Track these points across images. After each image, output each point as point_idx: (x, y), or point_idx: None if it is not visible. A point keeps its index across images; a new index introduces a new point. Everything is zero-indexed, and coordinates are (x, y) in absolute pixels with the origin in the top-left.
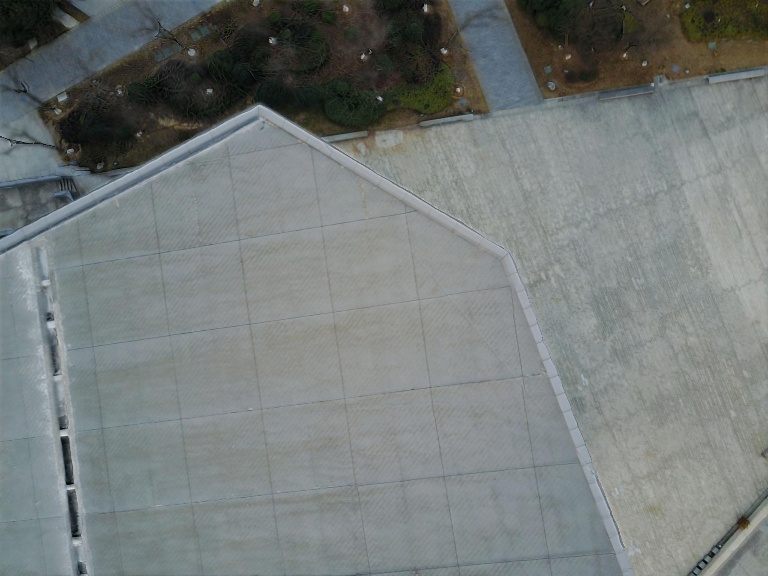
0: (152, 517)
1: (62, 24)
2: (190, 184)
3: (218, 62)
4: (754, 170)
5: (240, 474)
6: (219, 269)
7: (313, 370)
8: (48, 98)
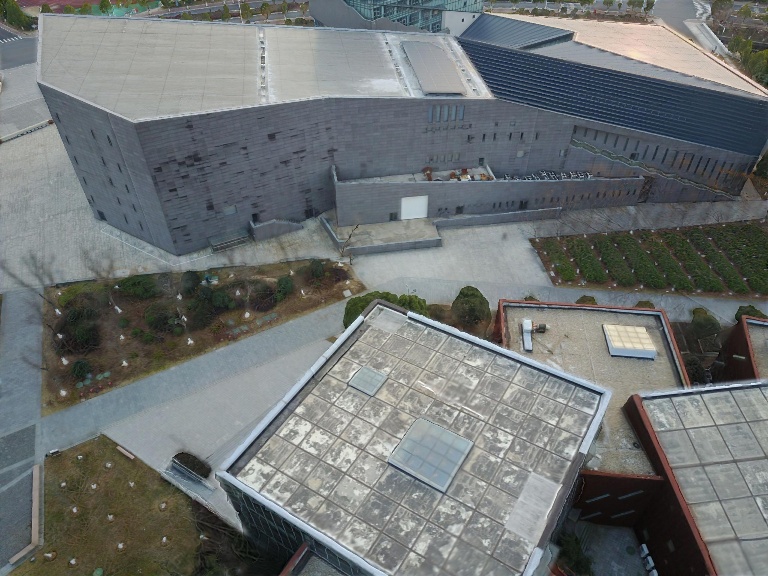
0: None
1: None
2: None
3: (221, 293)
4: None
5: (186, 52)
6: None
7: (143, 67)
8: (359, 294)
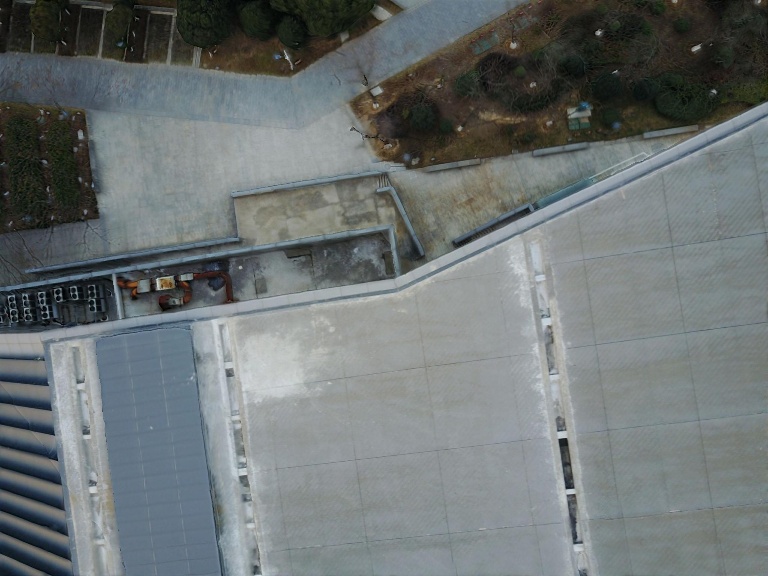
0: (667, 523)
1: (374, 17)
2: (708, 174)
3: (554, 54)
4: None
5: None
6: (742, 263)
7: None
8: (361, 92)
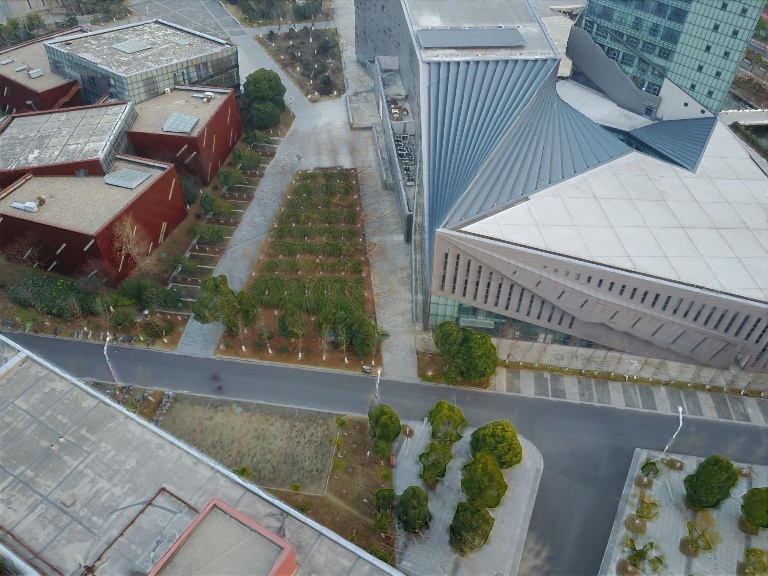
0: None
1: None
2: None
3: (308, 55)
4: None
5: None
6: None
7: None
8: None
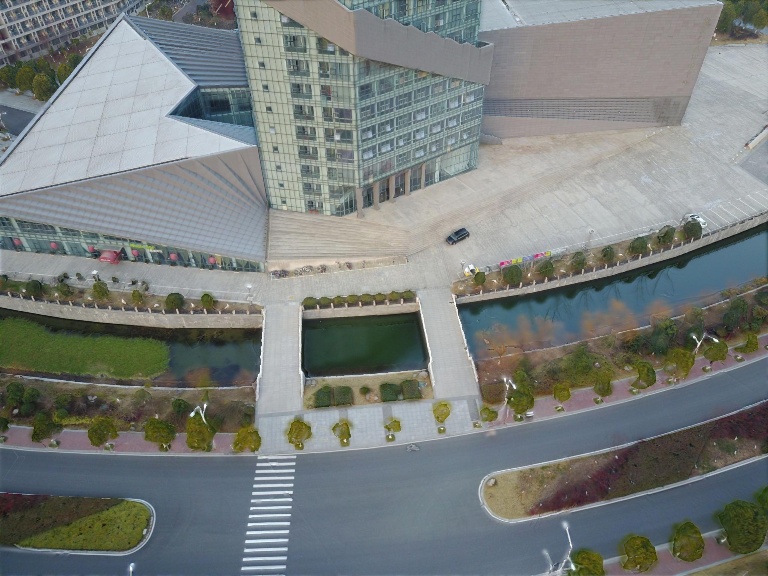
0: None
1: None
2: None
3: None
4: (714, 61)
5: None
6: None
7: None
8: None
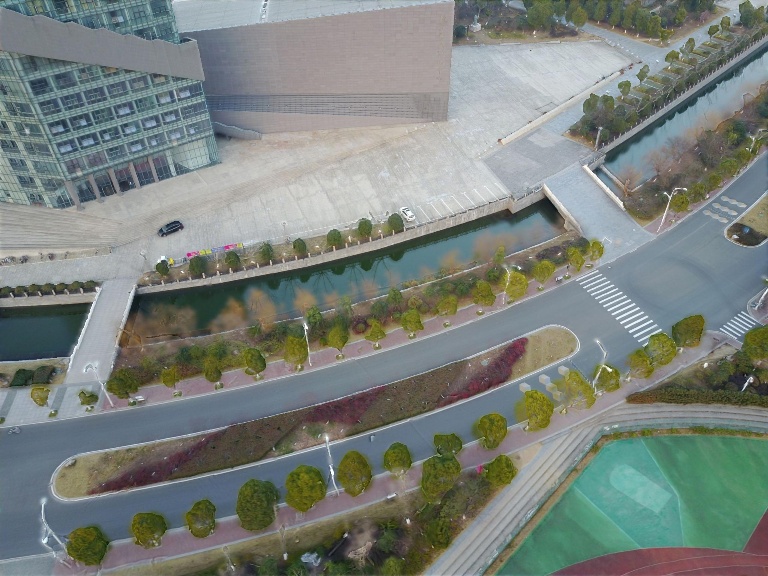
0: (292, 2)
1: None
2: None
3: None
4: (520, 58)
5: None
6: None
7: None
8: None
